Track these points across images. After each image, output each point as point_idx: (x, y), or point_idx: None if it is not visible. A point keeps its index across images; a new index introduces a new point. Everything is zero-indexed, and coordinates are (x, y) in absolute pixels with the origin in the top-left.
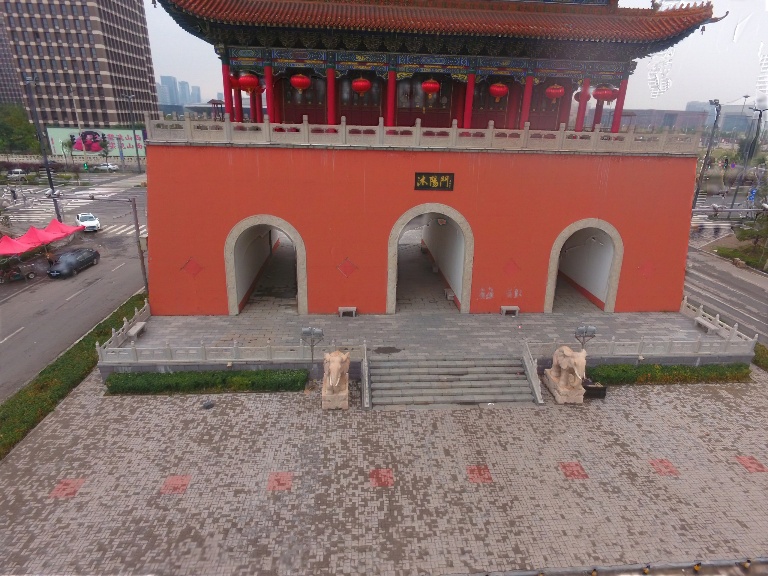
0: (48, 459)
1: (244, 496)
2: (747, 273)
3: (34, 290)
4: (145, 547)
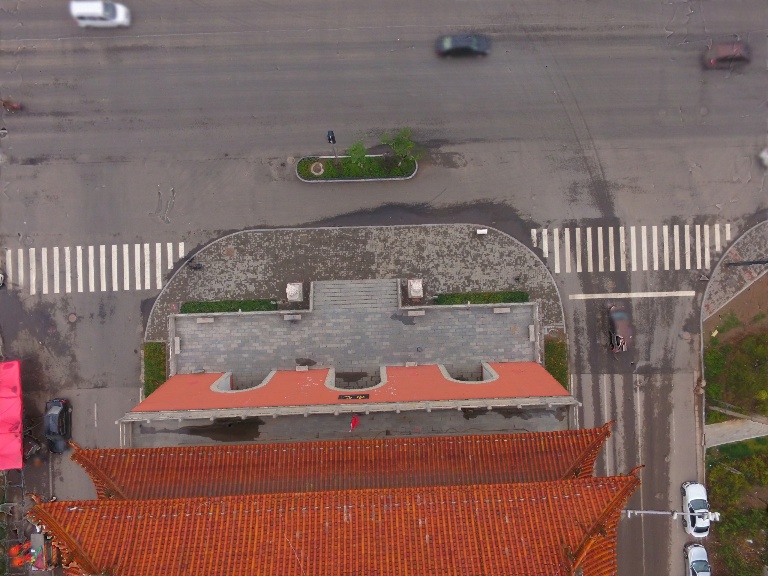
0: None
1: None
2: (689, 409)
3: (60, 475)
4: None
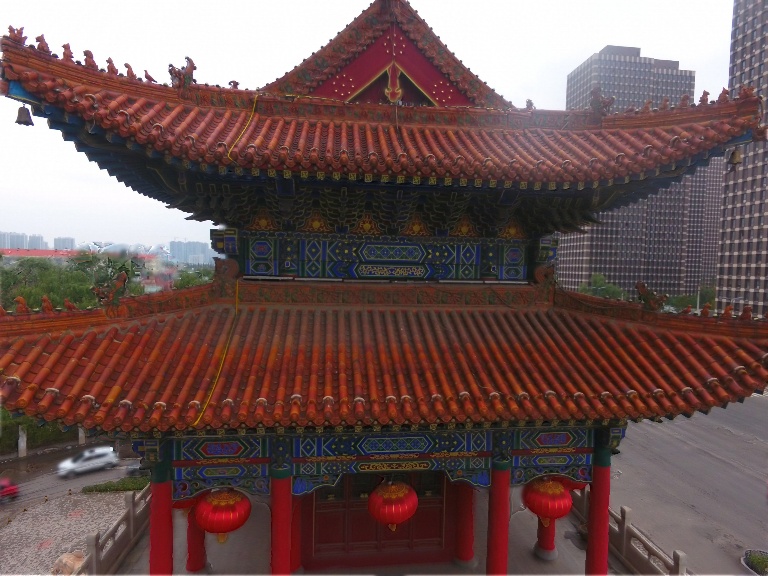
0: (107, 501)
1: (8, 568)
2: None
3: None
4: (5, 544)
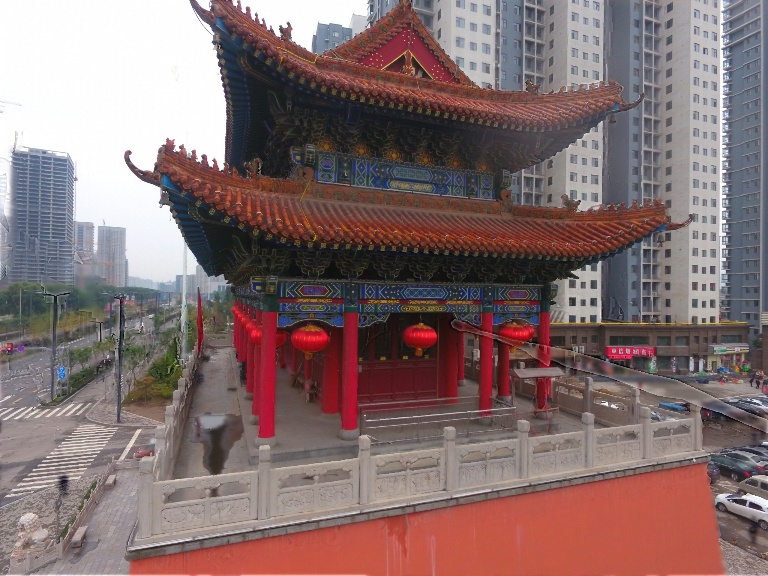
0: None
1: None
2: None
3: None
4: None
